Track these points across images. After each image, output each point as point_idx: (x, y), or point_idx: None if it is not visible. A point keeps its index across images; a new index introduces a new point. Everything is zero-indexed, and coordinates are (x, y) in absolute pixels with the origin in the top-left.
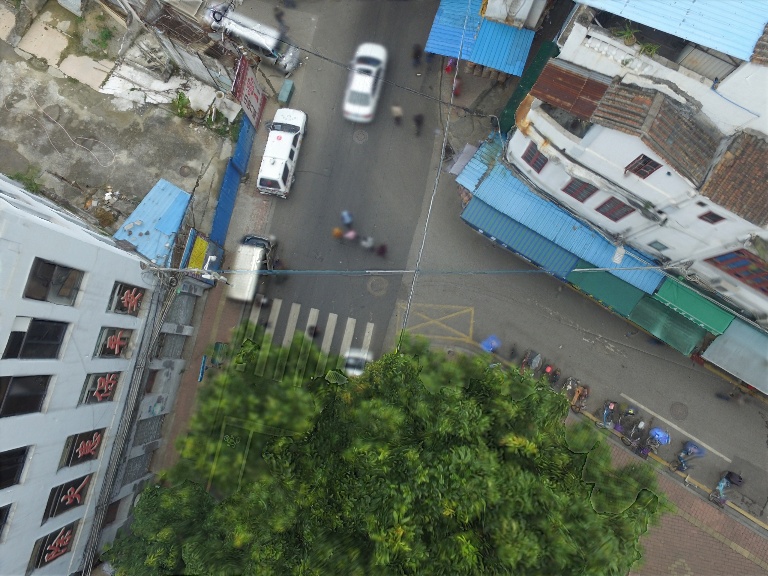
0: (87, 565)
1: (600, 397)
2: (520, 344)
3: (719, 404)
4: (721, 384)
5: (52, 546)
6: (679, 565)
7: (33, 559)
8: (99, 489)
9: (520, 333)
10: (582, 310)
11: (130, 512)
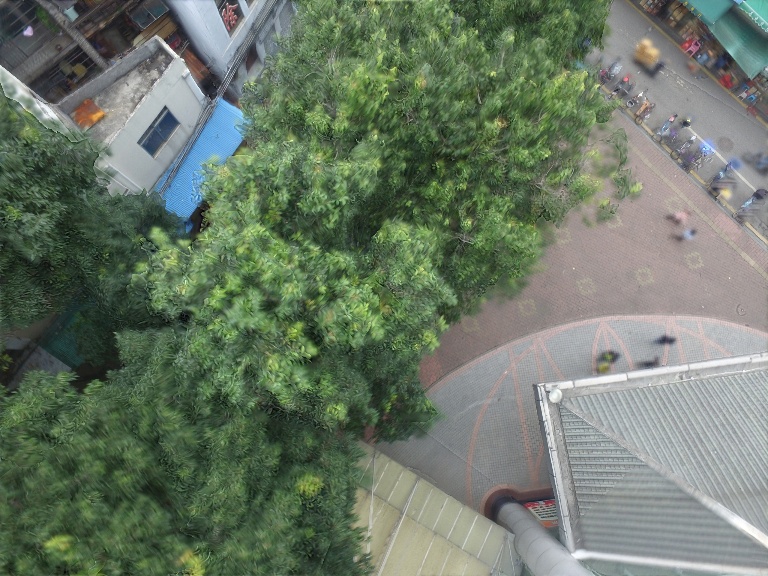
0: (233, 67)
1: (662, 118)
2: (605, 61)
3: (761, 148)
4: (767, 134)
5: (228, 8)
6: (694, 256)
7: (217, 2)
8: (259, 10)
9: (607, 53)
10: (665, 49)
11: (256, 81)
